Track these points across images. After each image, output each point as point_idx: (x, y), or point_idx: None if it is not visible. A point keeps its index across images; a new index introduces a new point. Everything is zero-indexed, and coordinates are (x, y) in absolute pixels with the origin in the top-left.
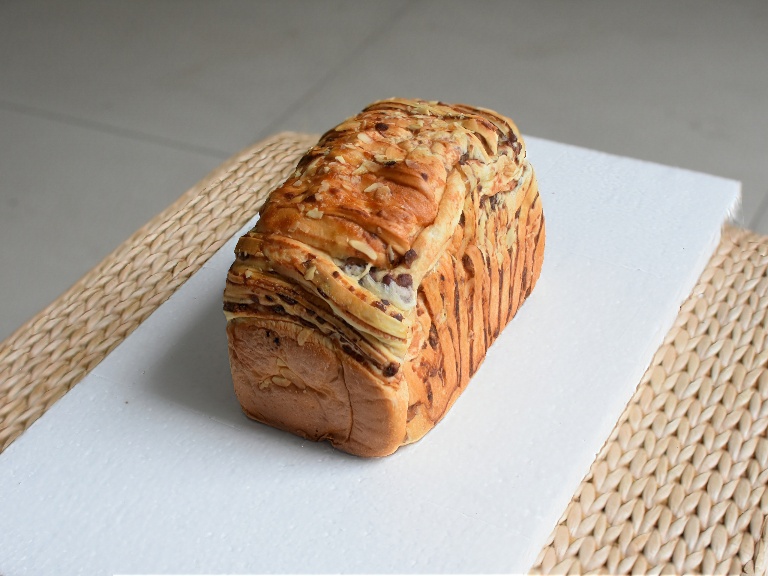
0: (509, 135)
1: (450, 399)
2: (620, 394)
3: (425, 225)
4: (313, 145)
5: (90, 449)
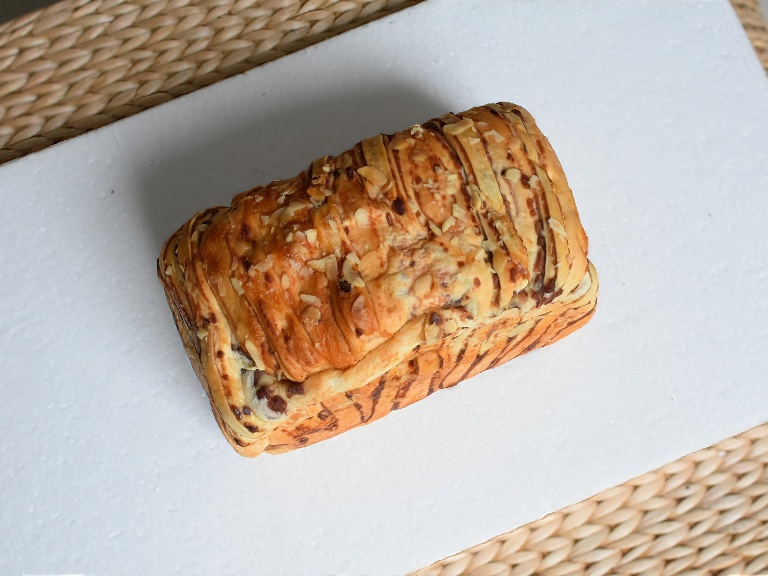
0: (548, 283)
1: (345, 430)
2: None
3: (336, 367)
4: None
5: (47, 227)
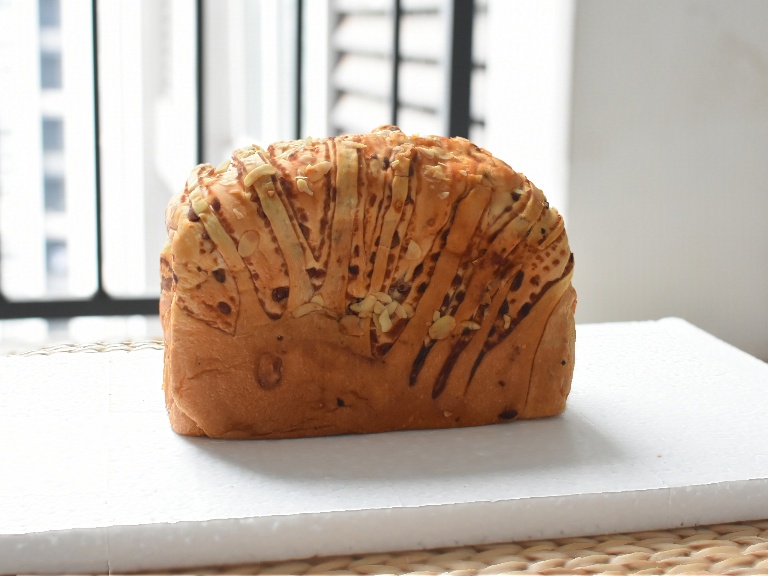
0: None
1: None
2: None
3: None
4: None
5: None
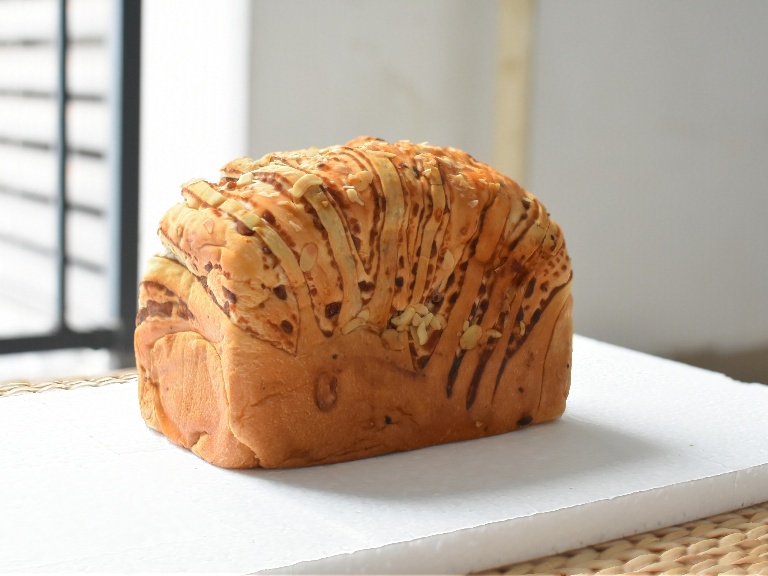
0: None
1: None
2: None
3: None
4: None
5: None
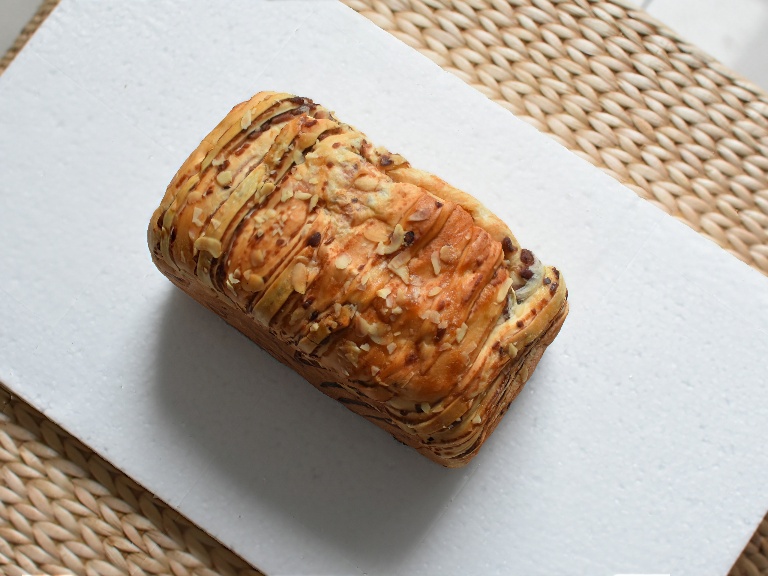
0: (296, 103)
1: None
2: None
3: None
4: None
5: None
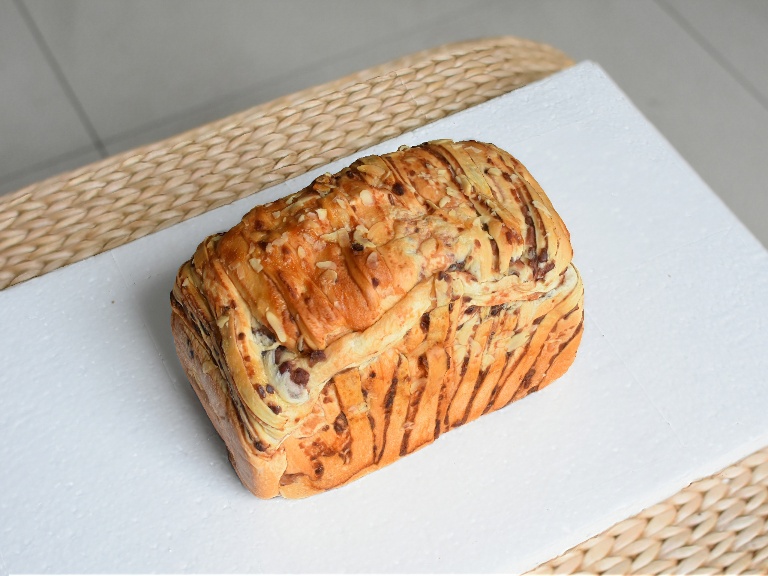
0: (540, 252)
1: (358, 473)
2: (523, 559)
3: (354, 329)
4: (521, 70)
5: (51, 335)
